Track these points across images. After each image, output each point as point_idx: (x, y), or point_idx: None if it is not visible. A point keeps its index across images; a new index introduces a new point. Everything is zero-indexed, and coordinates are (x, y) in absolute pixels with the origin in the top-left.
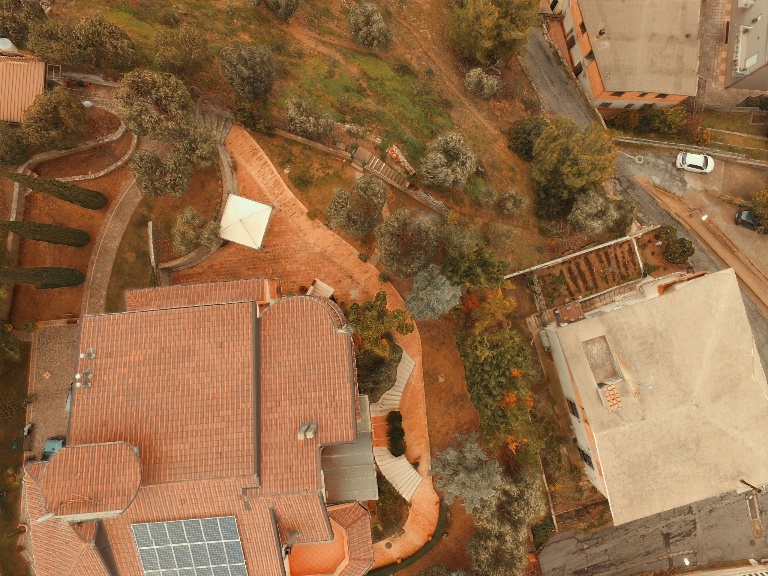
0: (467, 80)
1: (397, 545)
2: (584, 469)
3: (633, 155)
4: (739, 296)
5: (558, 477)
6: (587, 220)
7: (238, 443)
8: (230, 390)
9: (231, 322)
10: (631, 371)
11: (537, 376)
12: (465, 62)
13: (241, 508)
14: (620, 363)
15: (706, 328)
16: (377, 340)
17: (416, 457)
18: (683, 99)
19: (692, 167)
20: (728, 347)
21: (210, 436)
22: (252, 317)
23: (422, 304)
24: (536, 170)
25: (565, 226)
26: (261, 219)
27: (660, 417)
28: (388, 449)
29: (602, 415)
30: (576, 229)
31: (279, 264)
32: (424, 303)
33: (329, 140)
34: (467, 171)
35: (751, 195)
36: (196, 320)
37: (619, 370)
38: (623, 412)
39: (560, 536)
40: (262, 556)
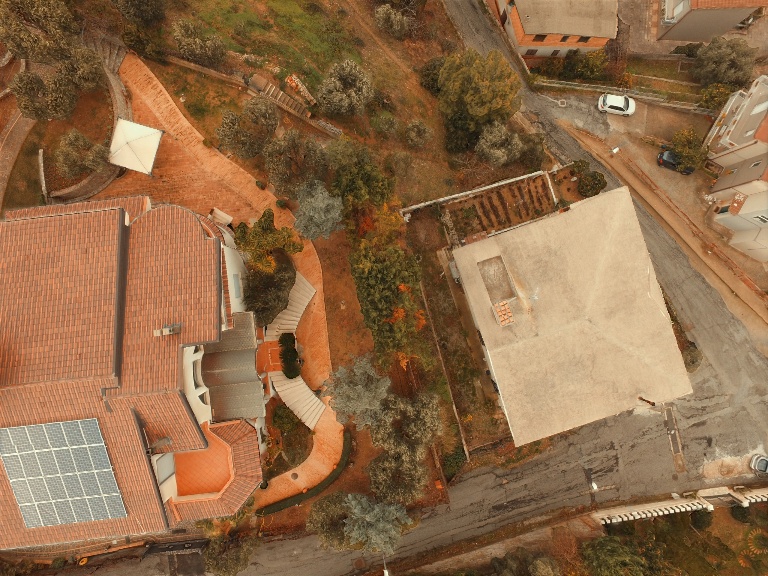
0: (376, 16)
1: (303, 475)
2: (498, 401)
3: (556, 99)
4: (634, 214)
5: (473, 411)
6: (491, 149)
7: (98, 344)
8: (93, 294)
9: (97, 229)
10: (525, 289)
11: (449, 309)
12: (380, 4)
13: (102, 410)
14: (515, 281)
15: (600, 245)
16: (261, 256)
17: (319, 385)
18: (607, 44)
19: (613, 108)
20: (622, 264)
21: (70, 338)
22: (118, 223)
23: (305, 218)
24: (442, 102)
25: (471, 157)
26: (151, 143)
27: (553, 333)
28: (283, 372)
29: (496, 333)
30: (483, 160)
31: (177, 193)
32: (307, 217)
33: (227, 70)
34: (364, 97)
35: (672, 135)
36: (62, 228)
37: (514, 288)
38: (517, 329)
39: (478, 471)
40: (129, 462)
